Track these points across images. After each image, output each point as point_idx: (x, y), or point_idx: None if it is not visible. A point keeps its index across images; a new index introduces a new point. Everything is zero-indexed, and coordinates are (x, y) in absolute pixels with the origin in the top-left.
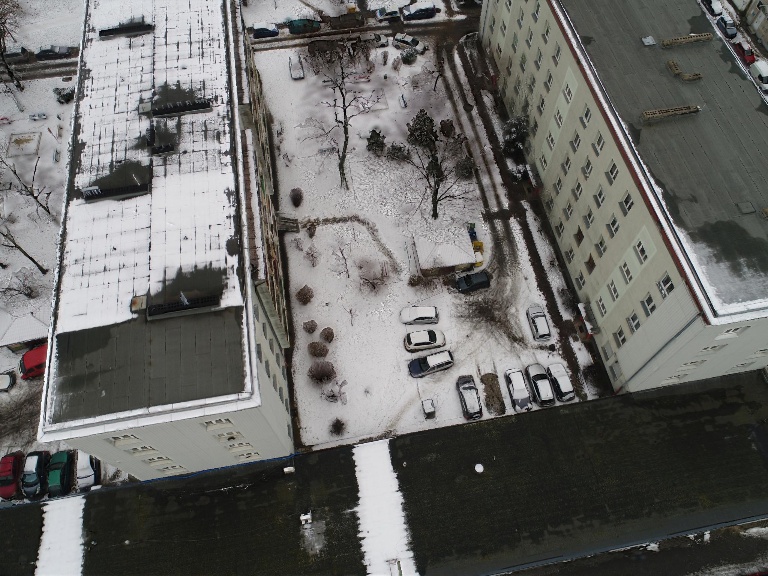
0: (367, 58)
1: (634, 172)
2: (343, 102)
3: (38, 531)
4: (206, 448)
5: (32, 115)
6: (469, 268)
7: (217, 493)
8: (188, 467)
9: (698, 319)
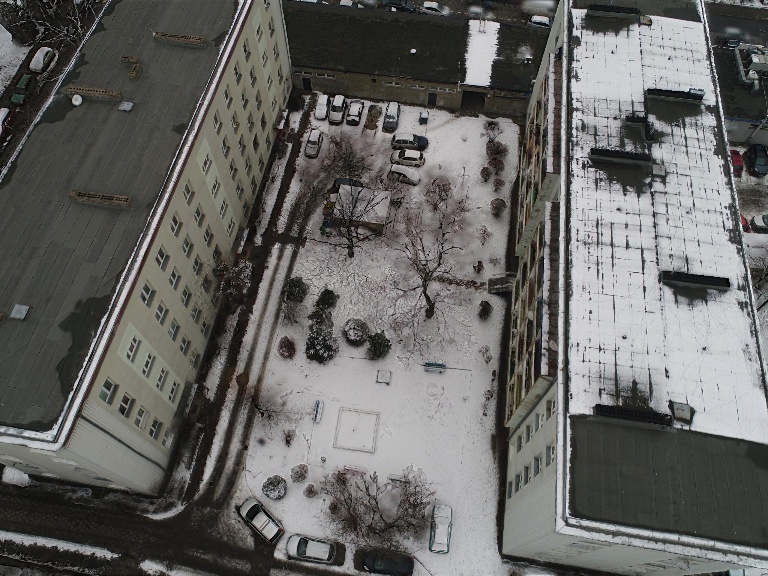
0: None
1: None
2: None
3: None
4: None
5: None
6: None
7: None
8: None
9: None
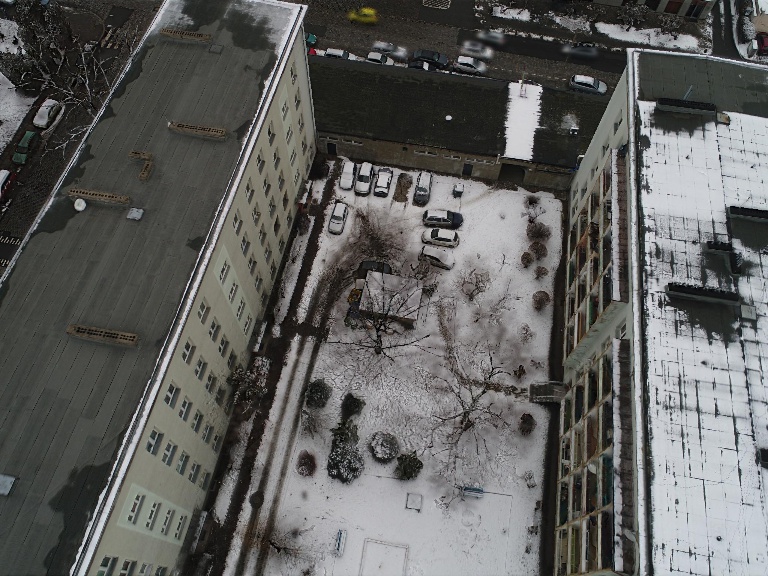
0: None
1: None
2: None
3: None
4: None
5: None
6: None
7: None
8: None
9: (302, 30)
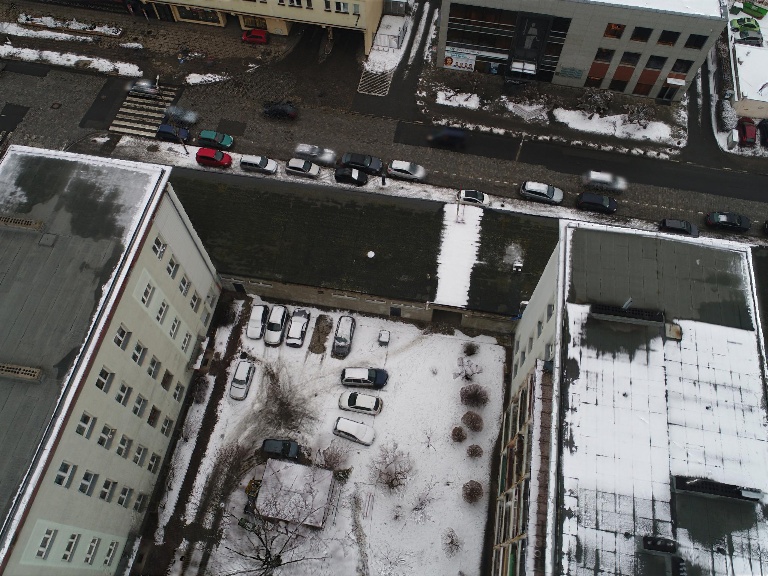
0: None
1: None
2: None
3: None
4: None
5: None
6: None
7: None
8: None
9: (169, 193)
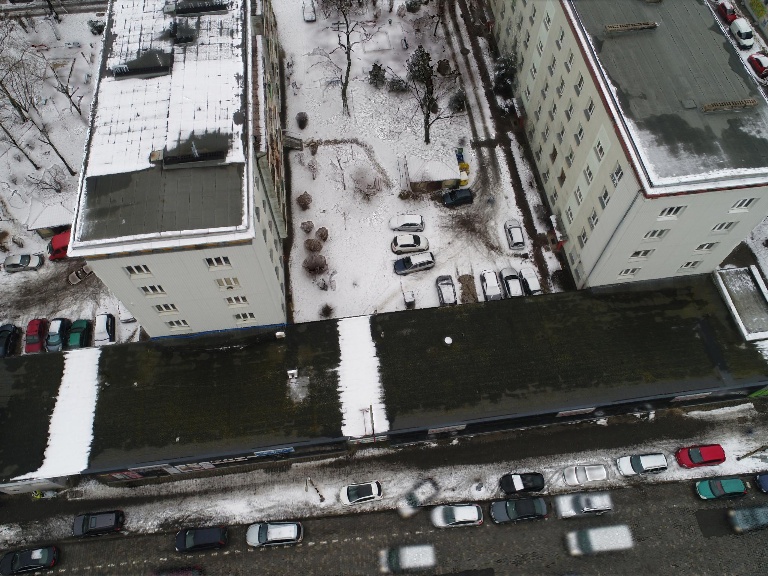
0: (374, 3)
1: (595, 77)
2: (347, 28)
3: (59, 373)
4: (208, 298)
5: (68, 43)
6: (455, 186)
7: (216, 351)
8: (192, 324)
9: (639, 195)
